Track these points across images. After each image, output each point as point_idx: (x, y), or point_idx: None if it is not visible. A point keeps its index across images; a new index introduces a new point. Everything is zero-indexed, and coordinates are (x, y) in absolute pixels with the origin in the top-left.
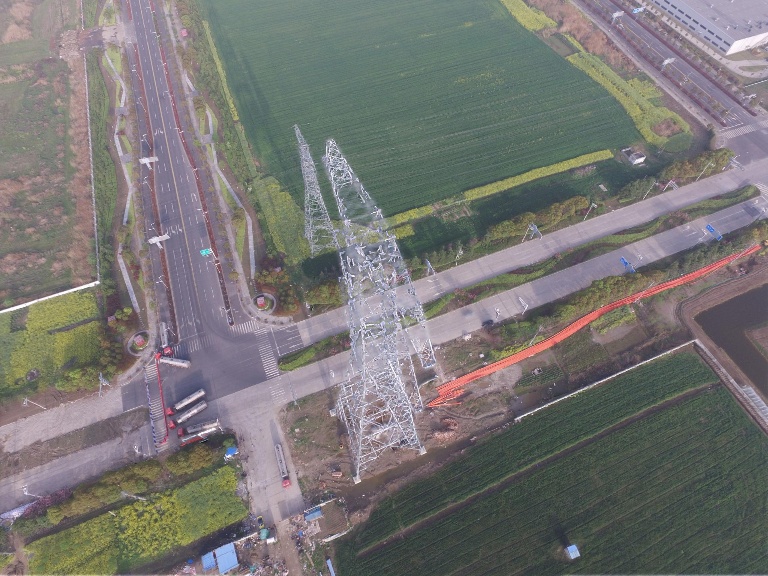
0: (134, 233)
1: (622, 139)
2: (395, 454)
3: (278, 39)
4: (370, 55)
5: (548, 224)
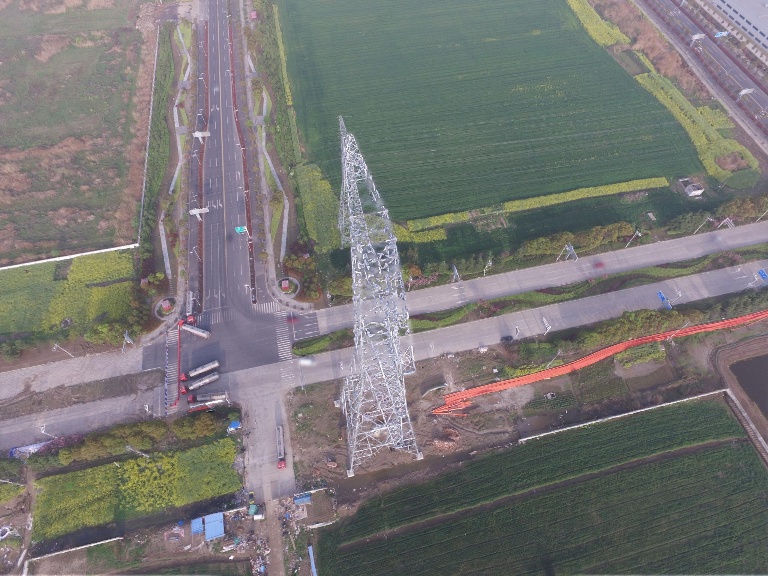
0: (178, 202)
1: (681, 168)
2: (392, 455)
3: (342, 29)
4: (431, 54)
5: (586, 246)
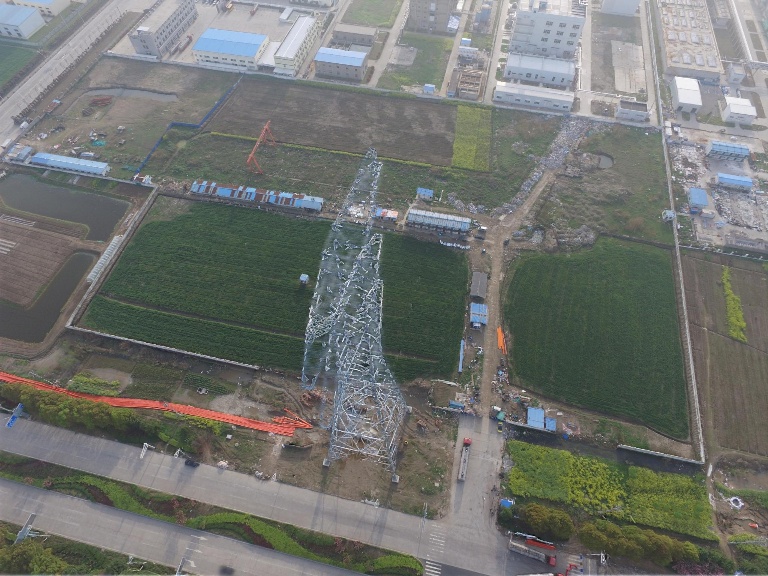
0: None
1: None
2: None
3: None
4: None
5: (1, 531)
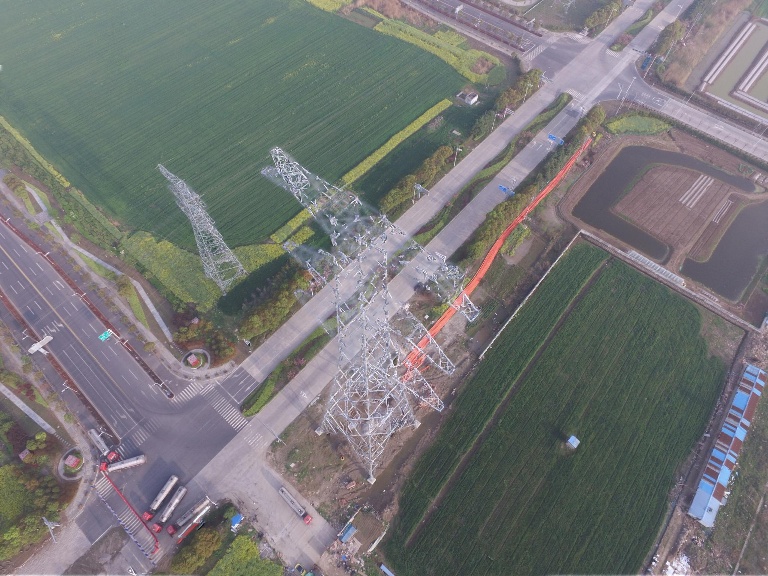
0: (3, 351)
1: (452, 86)
2: (394, 439)
3: (74, 87)
4: (186, 76)
5: (428, 180)
